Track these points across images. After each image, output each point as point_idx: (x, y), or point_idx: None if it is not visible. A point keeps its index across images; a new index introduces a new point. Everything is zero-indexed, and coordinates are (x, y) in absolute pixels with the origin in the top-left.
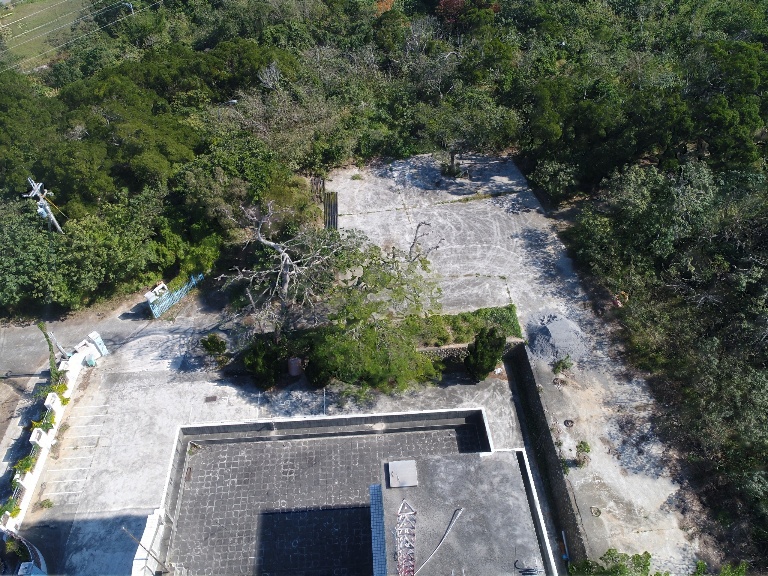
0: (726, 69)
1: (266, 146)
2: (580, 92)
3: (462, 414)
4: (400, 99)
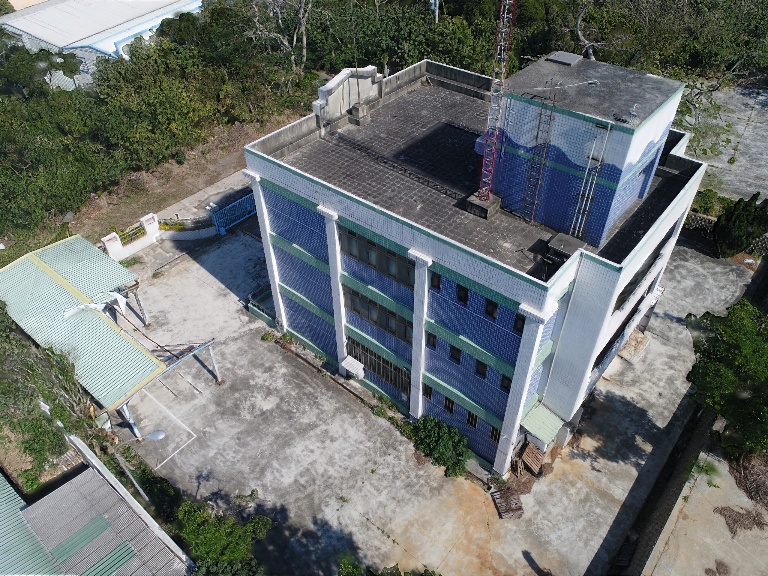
0: None
1: None
2: None
3: None
4: None
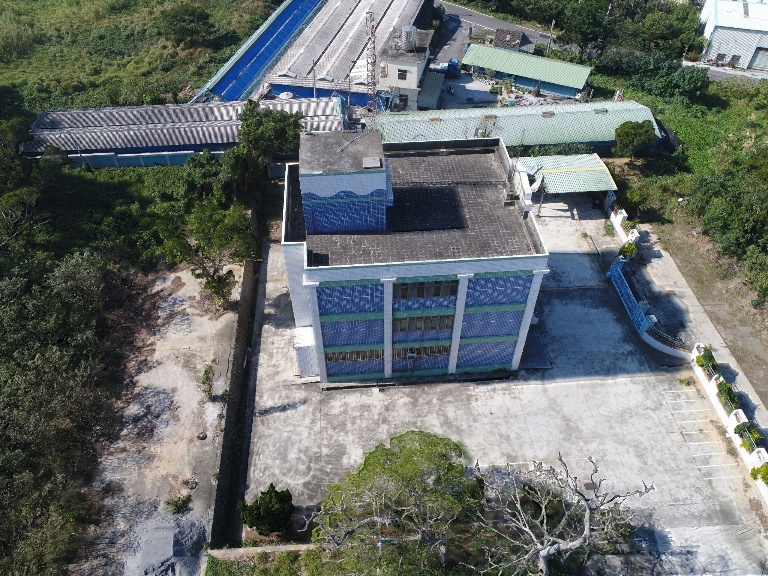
0: None
1: None
2: None
3: None
4: None
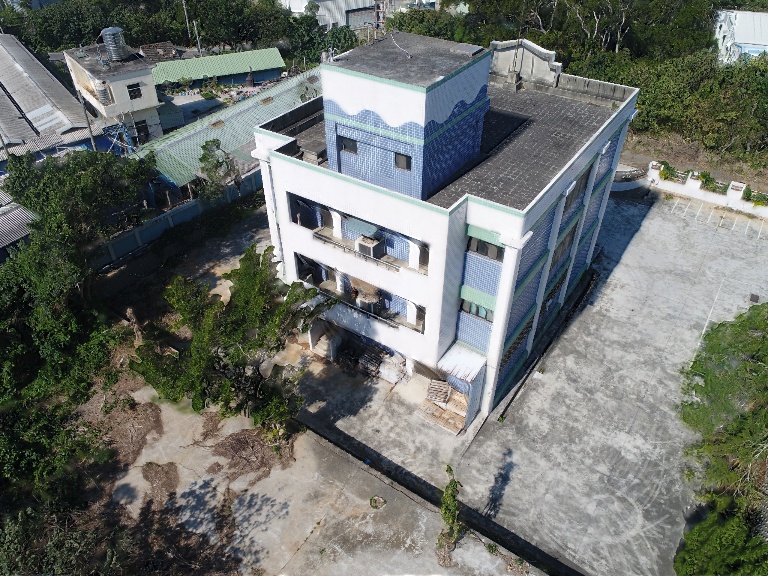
0: None
1: None
2: None
3: None
4: None
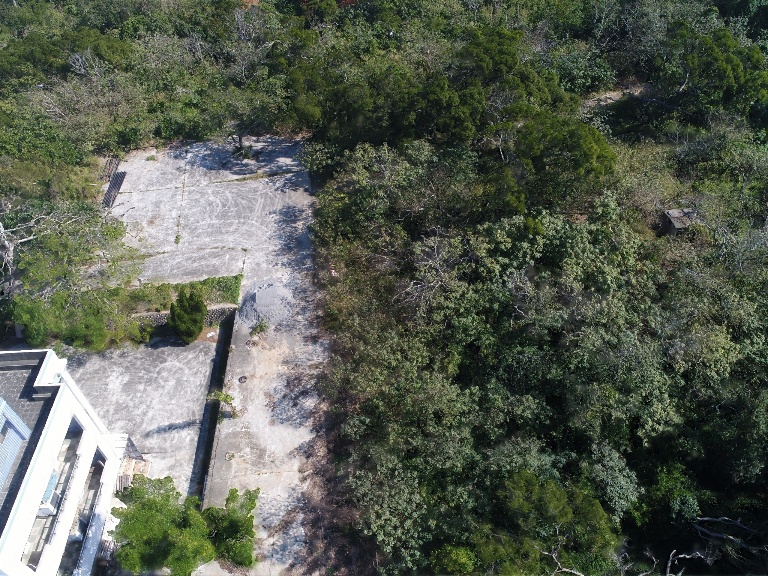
0: (460, 53)
1: (66, 128)
2: (341, 76)
3: (34, 355)
4: (215, 85)
